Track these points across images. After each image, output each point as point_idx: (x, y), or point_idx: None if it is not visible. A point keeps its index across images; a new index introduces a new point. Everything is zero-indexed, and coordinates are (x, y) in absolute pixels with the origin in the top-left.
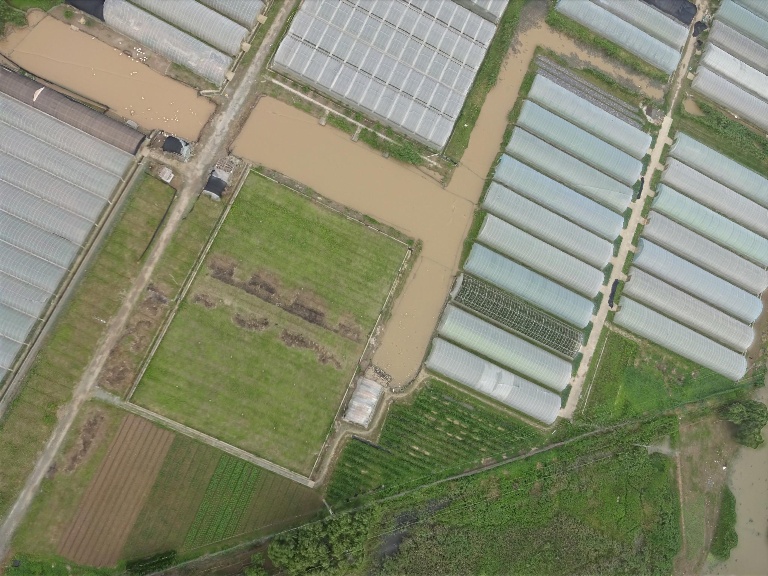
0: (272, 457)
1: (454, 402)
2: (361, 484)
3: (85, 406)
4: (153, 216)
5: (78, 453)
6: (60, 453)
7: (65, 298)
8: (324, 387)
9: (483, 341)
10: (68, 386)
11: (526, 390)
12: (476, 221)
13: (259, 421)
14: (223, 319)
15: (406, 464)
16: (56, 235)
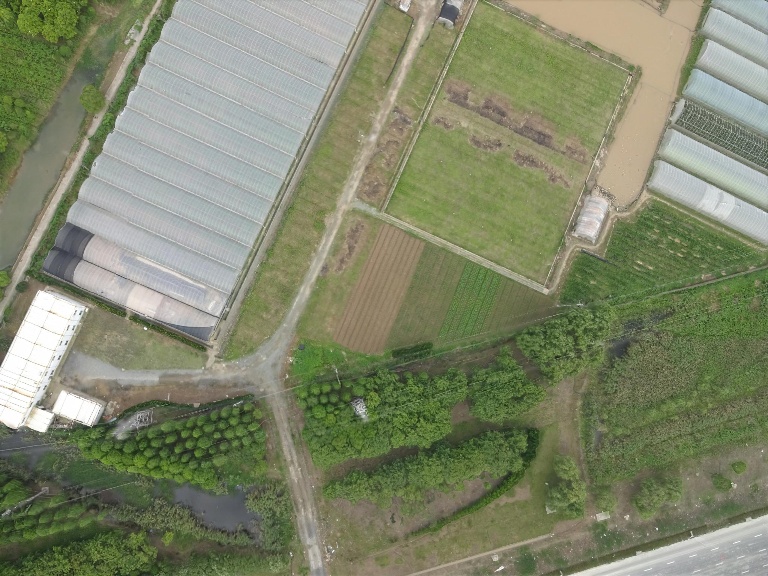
0: (510, 266)
1: (675, 221)
2: (590, 293)
3: (348, 215)
4: (394, 43)
5: (345, 256)
6: (330, 255)
7: (323, 119)
8: (554, 204)
9: (705, 162)
10: (332, 197)
11: (747, 209)
12: (694, 47)
13: (497, 233)
14: (461, 140)
15: (632, 276)
16: (315, 59)
